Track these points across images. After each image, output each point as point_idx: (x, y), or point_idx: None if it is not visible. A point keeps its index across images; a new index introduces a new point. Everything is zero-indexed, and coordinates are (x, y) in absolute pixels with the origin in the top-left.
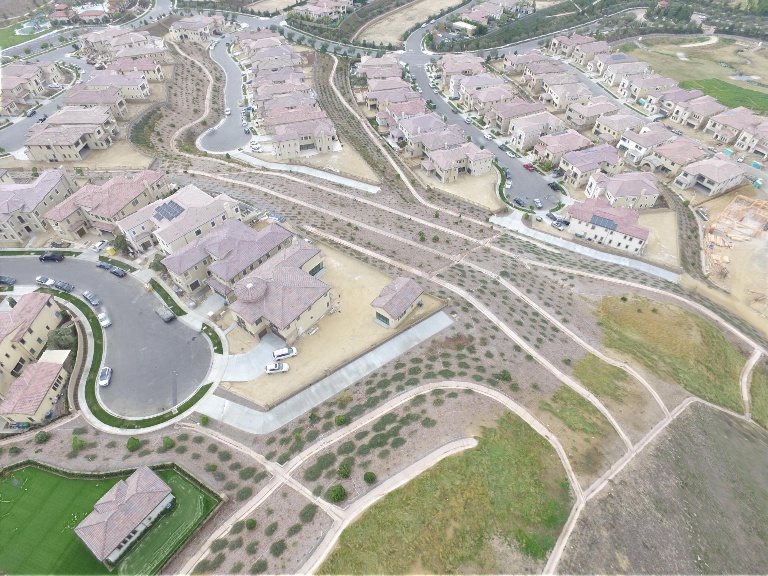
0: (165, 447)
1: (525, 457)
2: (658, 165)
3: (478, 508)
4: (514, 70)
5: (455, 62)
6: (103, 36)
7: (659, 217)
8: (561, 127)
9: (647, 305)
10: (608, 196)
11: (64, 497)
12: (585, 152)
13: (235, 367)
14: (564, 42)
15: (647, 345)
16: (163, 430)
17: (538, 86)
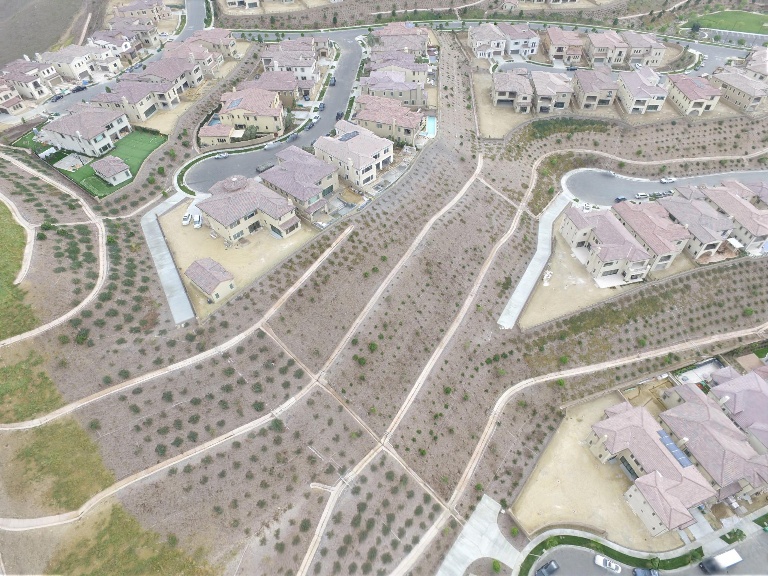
0: None
1: None
2: None
3: None
4: None
5: None
6: None
7: None
8: None
9: None
10: None
11: None
12: None
13: None
14: None
15: None
16: (171, 182)
17: None
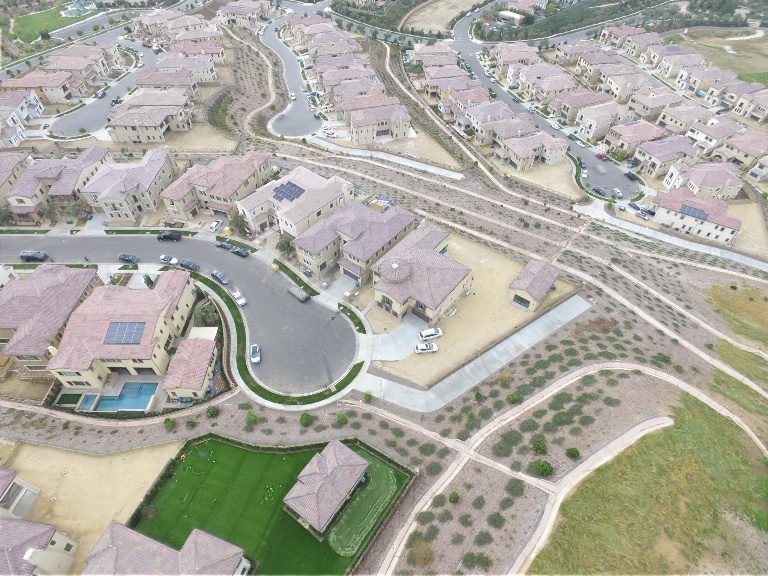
0: (340, 423)
1: (723, 436)
2: (730, 157)
3: (700, 483)
4: (567, 60)
5: (510, 51)
6: (157, 19)
7: (742, 208)
8: (630, 117)
9: (758, 294)
10: (691, 186)
11: (254, 470)
12: (661, 142)
13: (382, 347)
14: (615, 33)
15: (767, 333)
16: (327, 407)
17: (595, 77)
